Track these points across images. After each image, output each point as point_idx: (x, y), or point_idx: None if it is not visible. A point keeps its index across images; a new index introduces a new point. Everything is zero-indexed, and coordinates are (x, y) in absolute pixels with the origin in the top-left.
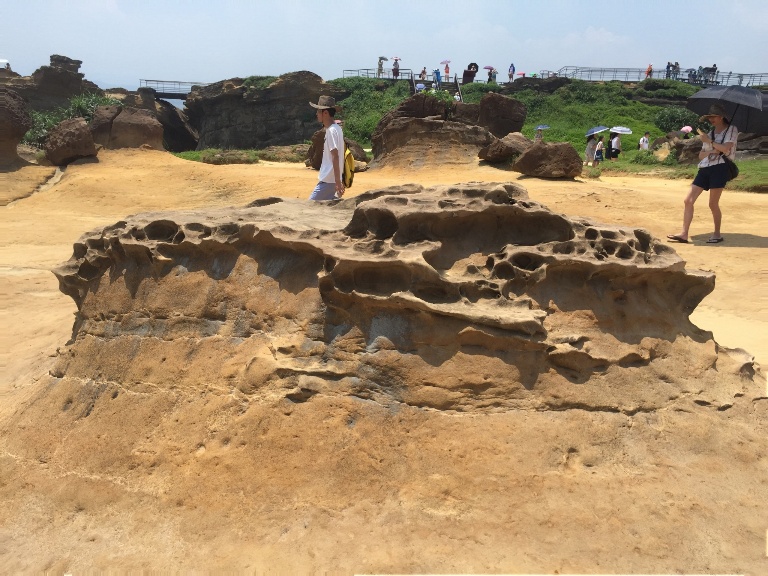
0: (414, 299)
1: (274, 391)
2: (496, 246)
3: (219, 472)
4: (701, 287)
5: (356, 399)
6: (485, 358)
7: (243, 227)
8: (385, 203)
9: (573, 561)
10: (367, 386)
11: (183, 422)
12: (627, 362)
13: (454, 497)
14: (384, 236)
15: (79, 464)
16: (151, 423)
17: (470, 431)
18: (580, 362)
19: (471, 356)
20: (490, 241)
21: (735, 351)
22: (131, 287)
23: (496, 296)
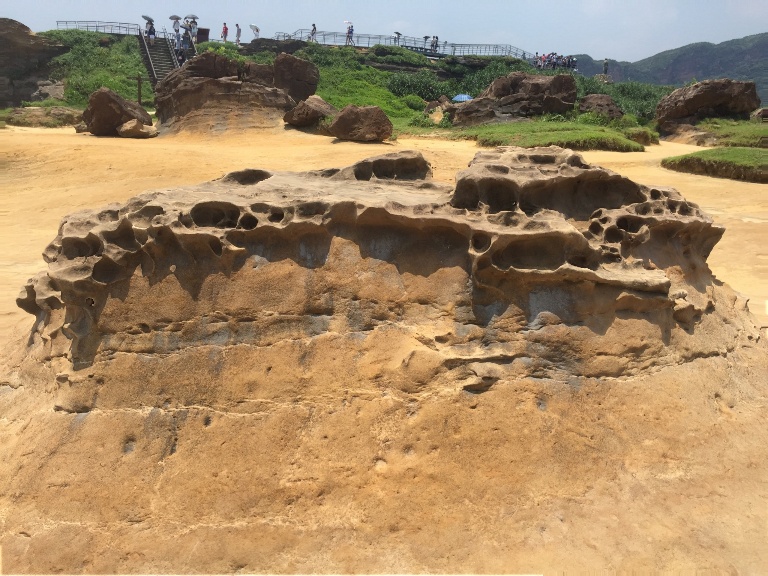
0: (584, 270)
1: (447, 385)
2: (582, 211)
3: (424, 484)
4: (714, 237)
5: (534, 380)
6: (636, 321)
7: (337, 205)
8: (490, 172)
9: None
10: (540, 365)
11: (337, 437)
12: (705, 310)
13: (672, 459)
14: (503, 207)
15: (204, 513)
16: (288, 446)
17: (649, 393)
18: (689, 314)
19: (626, 321)
20: (571, 206)
21: None
22: (190, 287)
23: (617, 260)
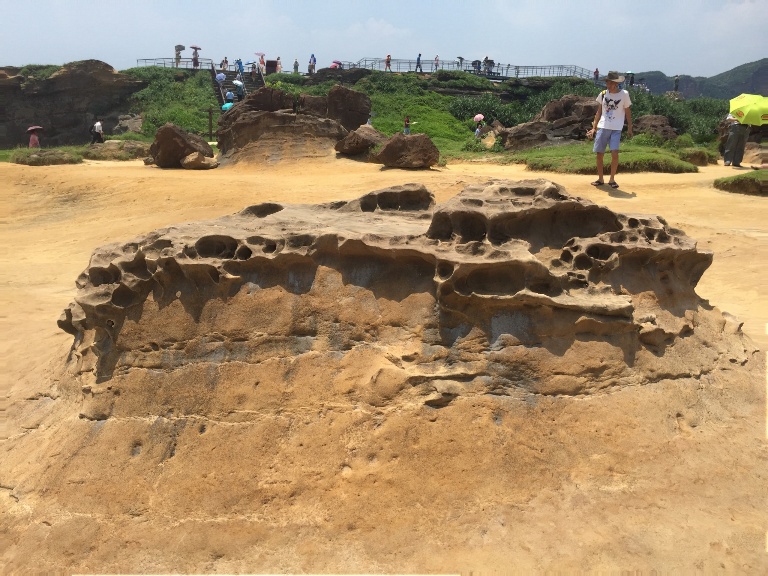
0: (540, 295)
1: (410, 400)
2: (558, 240)
3: (382, 489)
4: (703, 263)
5: (493, 396)
6: (596, 343)
7: (321, 237)
8: None
9: (737, 508)
10: (500, 383)
11: (311, 445)
12: (681, 333)
13: (618, 472)
14: (474, 237)
15: (193, 509)
16: (268, 452)
17: (604, 411)
18: (658, 338)
19: (586, 343)
20: (549, 235)
21: (723, 314)
22: (193, 311)
23: (584, 286)
